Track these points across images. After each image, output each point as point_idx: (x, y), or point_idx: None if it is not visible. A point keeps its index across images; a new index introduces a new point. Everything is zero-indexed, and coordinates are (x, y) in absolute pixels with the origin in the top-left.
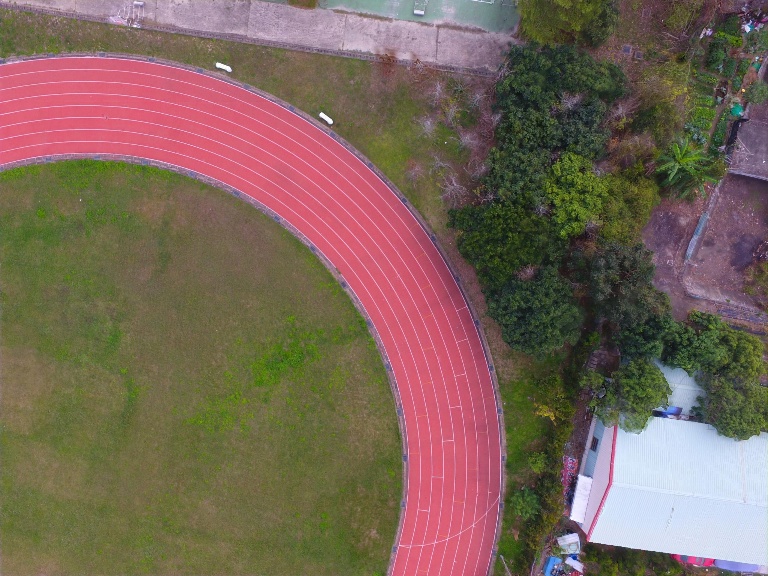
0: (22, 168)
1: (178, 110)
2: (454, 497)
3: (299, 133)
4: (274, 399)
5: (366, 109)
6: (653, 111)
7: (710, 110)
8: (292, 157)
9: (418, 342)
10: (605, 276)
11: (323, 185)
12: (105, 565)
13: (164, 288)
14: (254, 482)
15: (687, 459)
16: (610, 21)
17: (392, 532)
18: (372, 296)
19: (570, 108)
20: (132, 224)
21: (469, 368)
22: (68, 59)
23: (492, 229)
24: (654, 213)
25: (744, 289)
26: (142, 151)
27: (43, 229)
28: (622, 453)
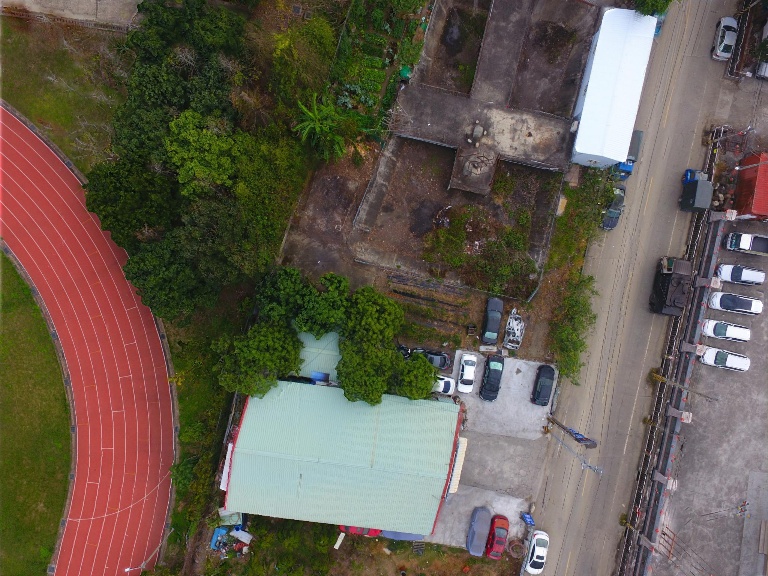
0: None
1: None
2: (125, 469)
3: None
4: None
5: (26, 69)
6: (275, 67)
7: (379, 72)
8: None
9: (85, 310)
10: (189, 233)
11: None
12: None
13: None
14: None
15: (317, 424)
16: None
17: (59, 505)
18: (36, 263)
19: (192, 64)
20: None
21: (139, 336)
22: None
23: None
24: (322, 177)
25: (423, 255)
26: None
27: None
28: (250, 419)
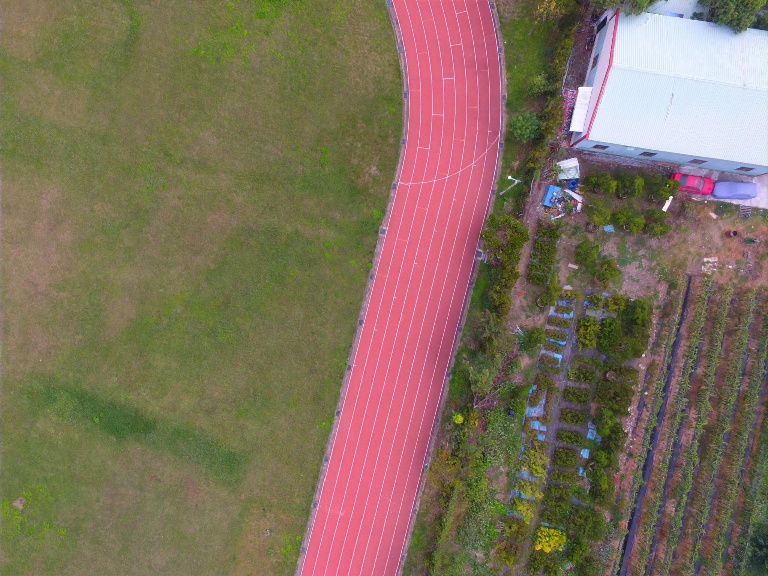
0: None
1: None
2: (454, 135)
3: None
4: (275, 32)
5: None
6: None
7: None
8: None
9: None
10: None
11: None
12: (106, 193)
13: None
14: (255, 115)
15: (687, 47)
16: None
17: (392, 168)
18: None
19: None
20: None
21: (470, 5)
22: None
23: None
24: None
25: None
26: None
27: None
28: (622, 40)
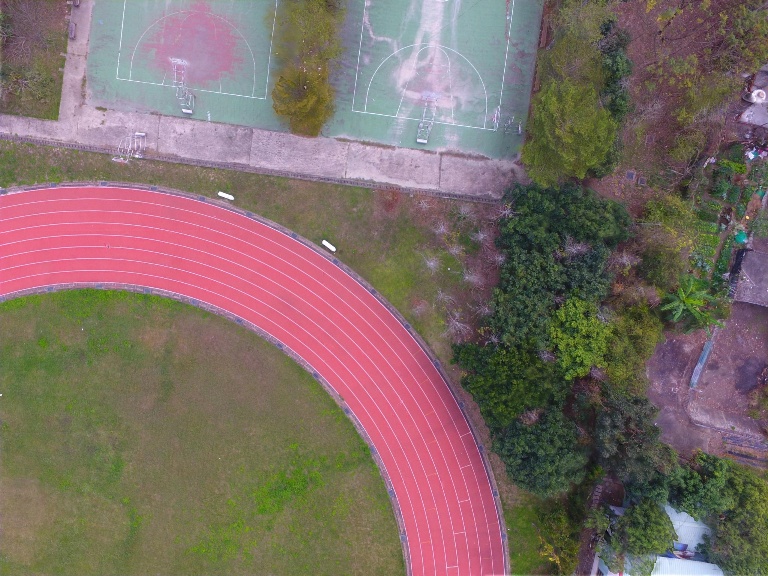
0: (23, 298)
1: (180, 238)
2: None
3: (302, 260)
4: (277, 527)
5: (369, 236)
6: (658, 255)
7: (714, 237)
8: (295, 284)
9: (422, 468)
10: (611, 435)
11: (326, 312)
12: None
13: (166, 417)
14: None
15: None
16: (614, 158)
17: None
18: (375, 422)
19: (574, 252)
20: (134, 353)
21: (473, 494)
22: (70, 189)
23: (496, 375)
24: None
25: (749, 413)
26: (144, 280)
27: (45, 359)
28: None
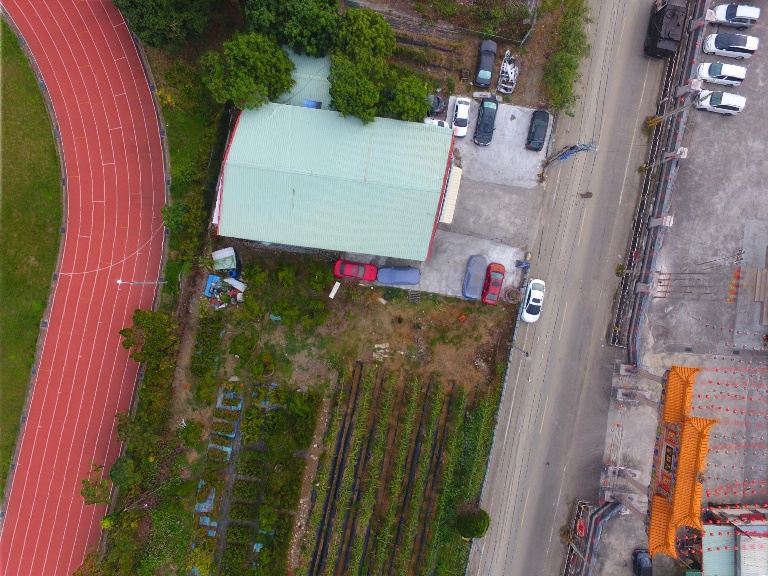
0: None
1: None
2: (117, 223)
3: None
4: None
5: None
6: None
7: None
8: None
9: (74, 60)
10: None
11: None
12: None
13: None
14: None
15: (310, 141)
16: None
17: (51, 258)
18: (23, 11)
19: None
20: None
21: (129, 87)
22: None
23: None
24: None
25: (415, 6)
26: None
27: None
28: (242, 134)
